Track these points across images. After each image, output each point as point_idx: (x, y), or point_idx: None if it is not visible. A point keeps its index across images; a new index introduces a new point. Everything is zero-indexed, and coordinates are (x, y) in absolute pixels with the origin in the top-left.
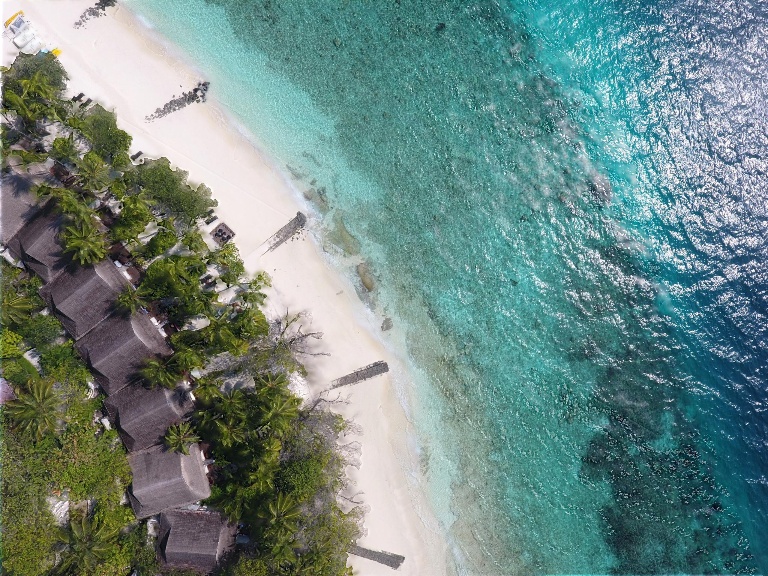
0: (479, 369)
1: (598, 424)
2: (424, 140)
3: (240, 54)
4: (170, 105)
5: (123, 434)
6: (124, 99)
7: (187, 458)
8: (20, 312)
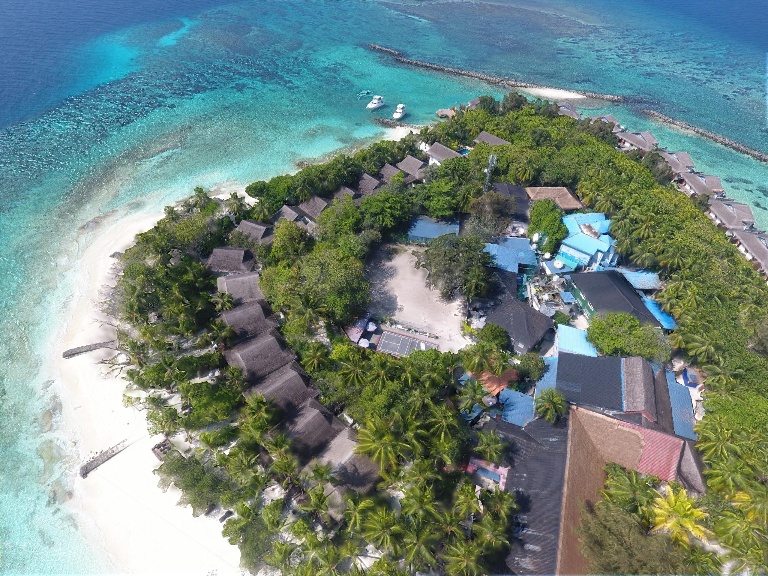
0: None
1: None
2: None
3: None
4: None
5: (267, 308)
6: None
7: None
8: None
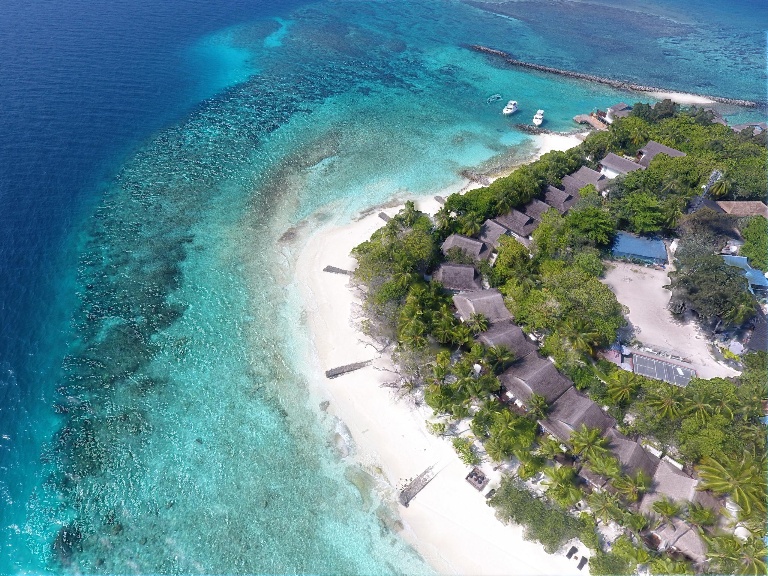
0: (249, 373)
1: (161, 335)
2: None
3: None
4: None
5: None
6: None
7: None
8: (614, 385)
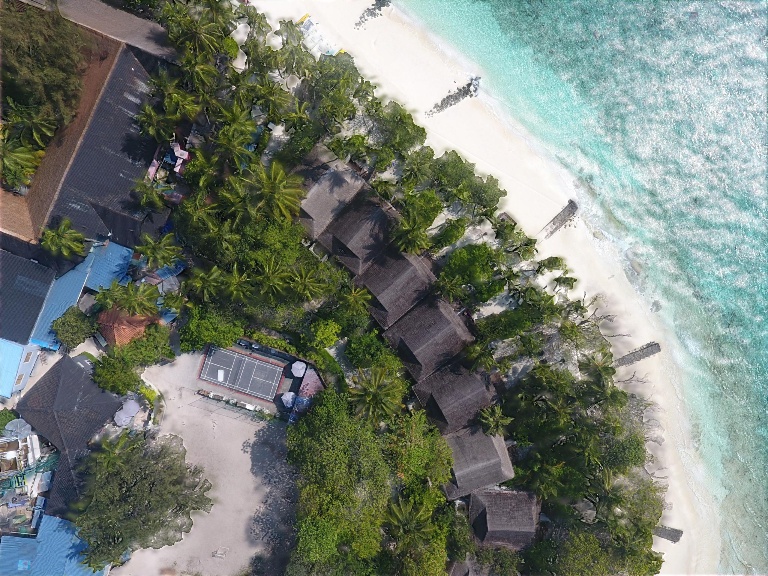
0: (743, 347)
1: None
2: (682, 126)
3: (507, 49)
4: (447, 100)
5: (433, 419)
6: (405, 96)
7: (496, 440)
8: None
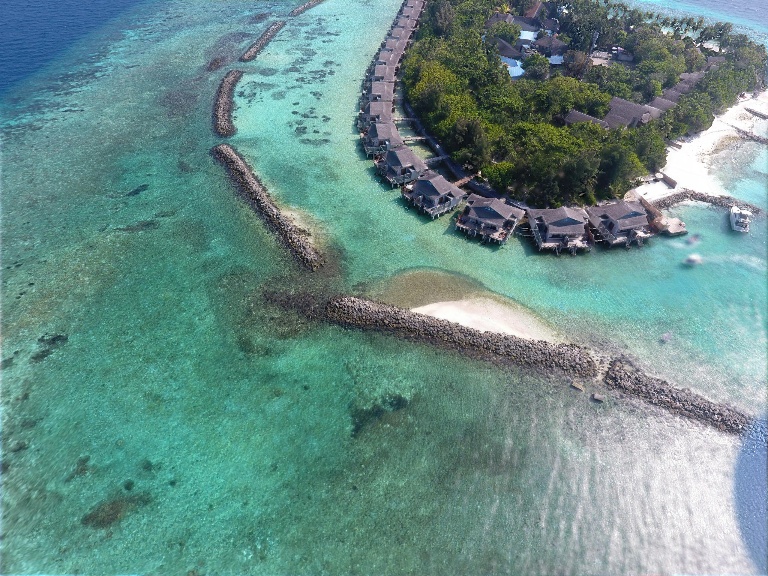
0: None
1: None
2: None
3: None
4: None
5: None
6: None
7: None
8: None
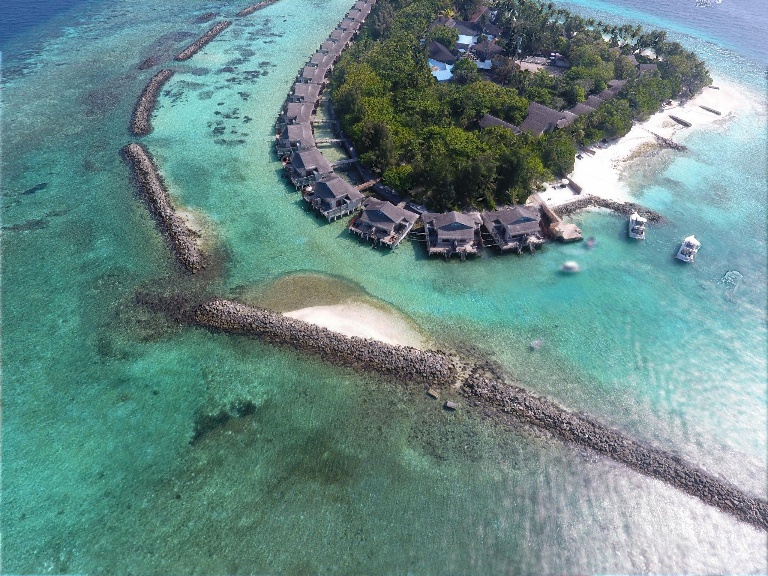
0: None
1: None
2: None
3: None
4: None
5: None
6: None
7: None
8: None
